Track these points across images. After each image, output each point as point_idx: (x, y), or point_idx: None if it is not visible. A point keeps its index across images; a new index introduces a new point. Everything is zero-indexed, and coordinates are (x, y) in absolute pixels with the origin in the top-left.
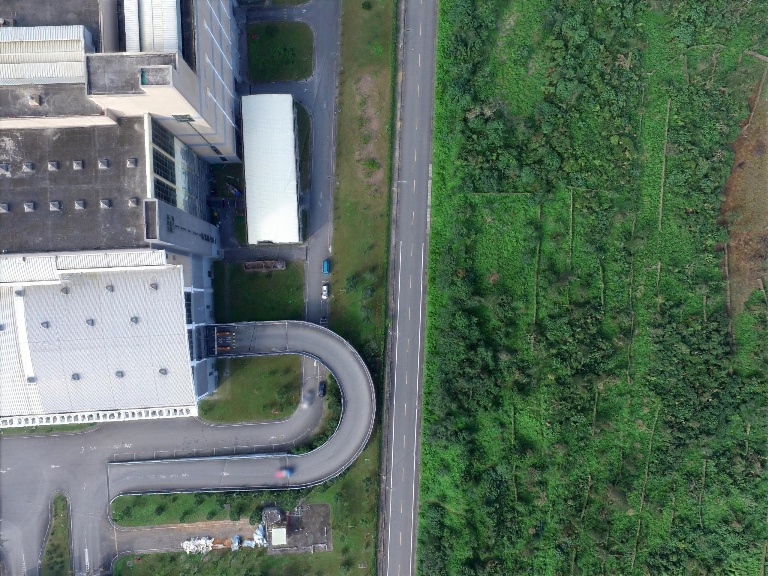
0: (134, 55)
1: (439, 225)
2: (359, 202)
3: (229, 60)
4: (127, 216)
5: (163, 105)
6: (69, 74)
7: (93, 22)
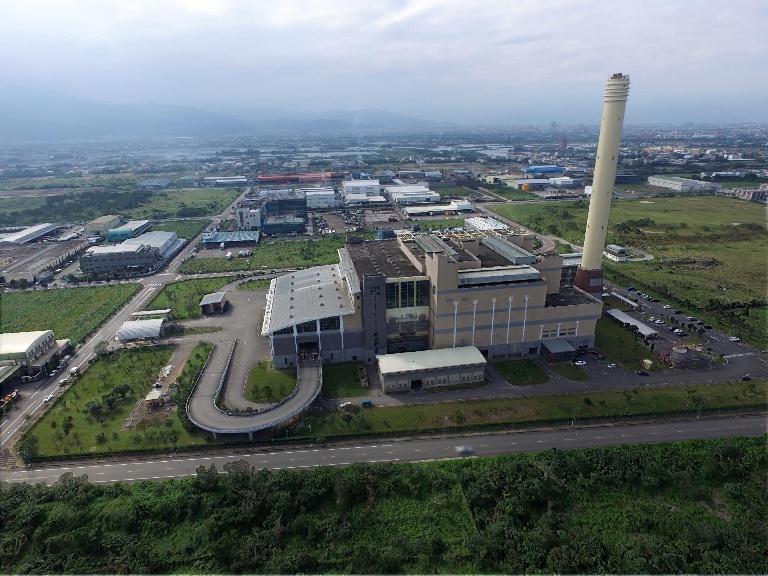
0: None
1: None
2: (425, 415)
3: (495, 341)
4: None
5: (433, 272)
6: None
7: None
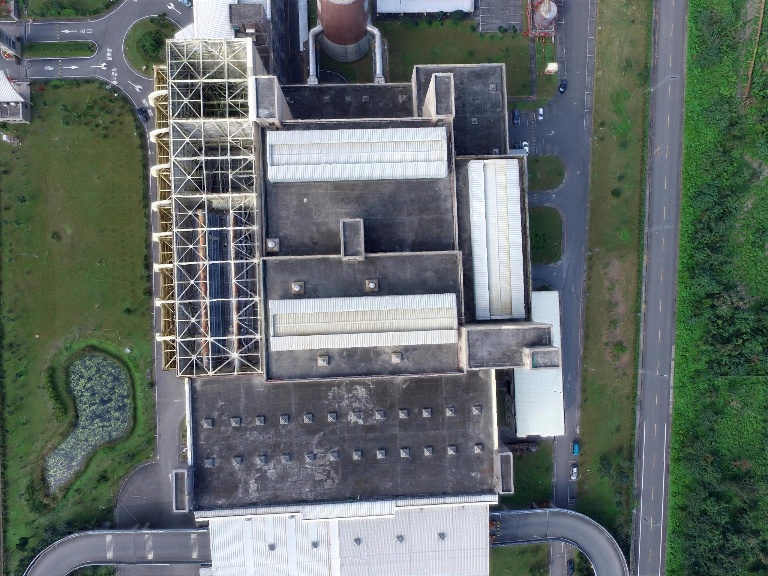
0: (511, 328)
1: (682, 406)
2: (607, 384)
3: None
4: (472, 461)
5: None
6: (442, 341)
7: (450, 280)
